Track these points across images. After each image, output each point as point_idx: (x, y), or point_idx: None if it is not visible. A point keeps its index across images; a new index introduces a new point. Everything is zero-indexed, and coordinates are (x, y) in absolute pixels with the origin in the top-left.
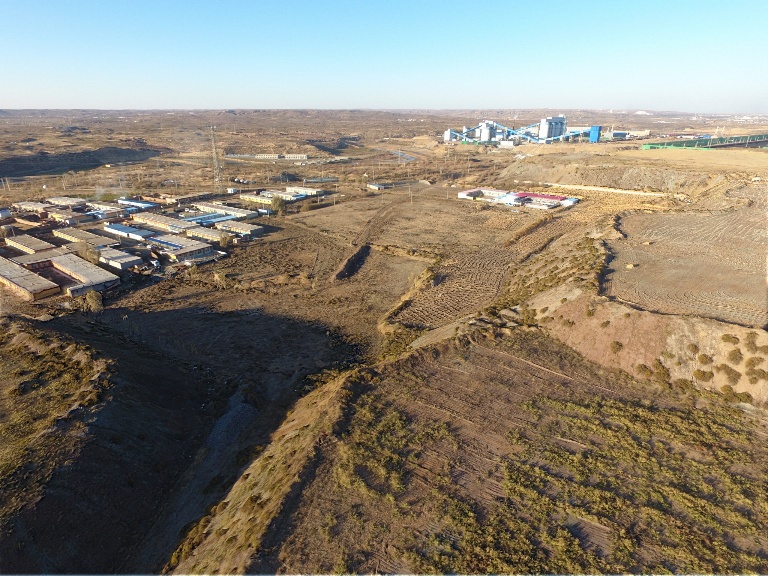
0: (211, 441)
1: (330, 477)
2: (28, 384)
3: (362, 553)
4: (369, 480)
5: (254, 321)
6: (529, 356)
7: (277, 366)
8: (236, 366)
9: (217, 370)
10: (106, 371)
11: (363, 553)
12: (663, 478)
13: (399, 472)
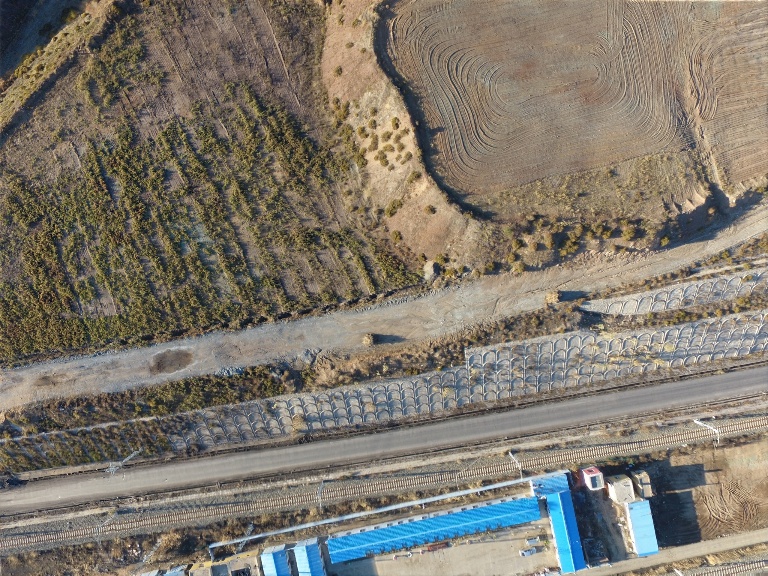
0: None
1: (75, 79)
2: None
3: (69, 131)
4: (94, 92)
5: None
6: (282, 37)
7: None
8: None
9: None
10: None
11: (70, 131)
12: (243, 176)
13: (112, 95)
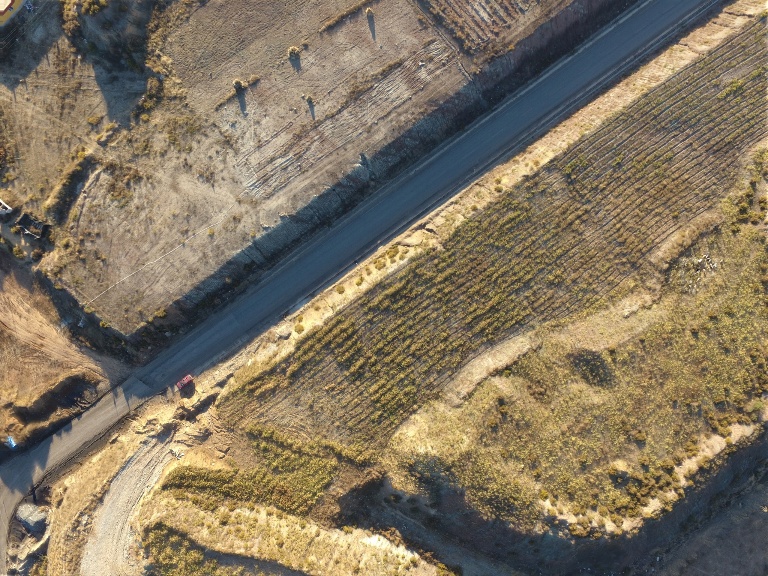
0: None
1: None
2: (623, 475)
3: None
4: None
5: None
6: None
7: None
8: None
9: None
10: (615, 534)
11: None
12: None
13: None
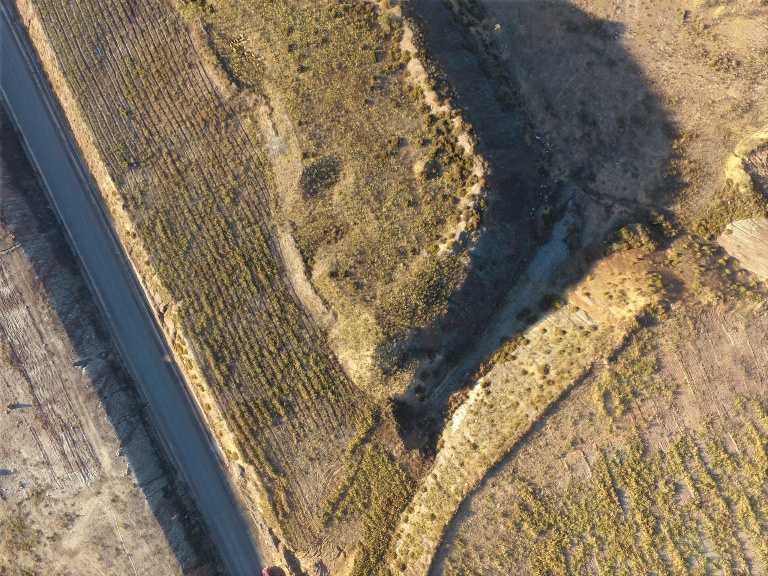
0: (531, 271)
1: (589, 389)
2: (429, 167)
3: (581, 440)
4: (607, 402)
5: (616, 63)
6: None
7: (605, 178)
8: (572, 156)
9: (555, 153)
10: (484, 186)
11: (582, 440)
12: (752, 492)
13: (625, 406)
